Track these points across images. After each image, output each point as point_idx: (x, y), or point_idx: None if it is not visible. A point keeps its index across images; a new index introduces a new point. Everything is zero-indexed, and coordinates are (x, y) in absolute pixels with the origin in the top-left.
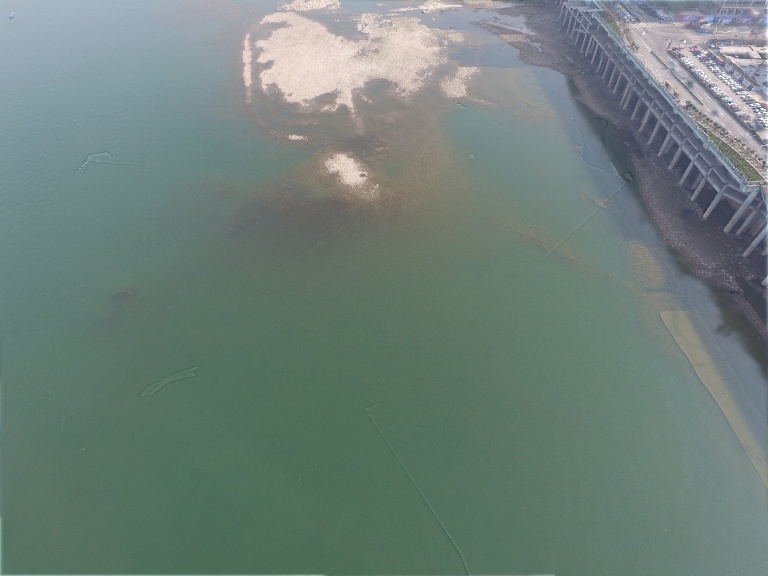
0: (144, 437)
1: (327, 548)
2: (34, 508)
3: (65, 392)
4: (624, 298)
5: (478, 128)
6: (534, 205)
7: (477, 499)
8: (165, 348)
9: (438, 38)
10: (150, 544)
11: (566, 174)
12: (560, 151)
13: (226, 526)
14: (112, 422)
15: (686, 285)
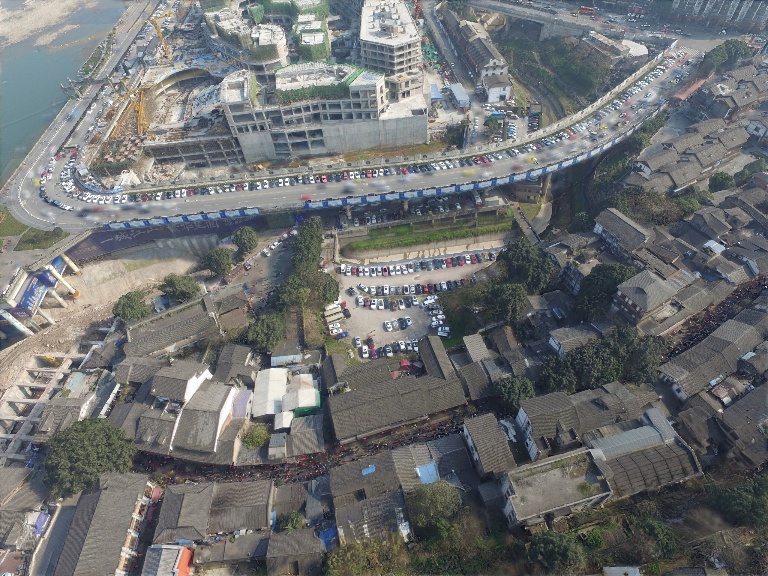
0: None
1: None
2: None
3: None
4: (2, 154)
5: (33, 65)
6: (10, 108)
7: None
8: None
9: (77, 6)
10: None
11: (57, 89)
12: (73, 76)
13: None
14: None
15: None
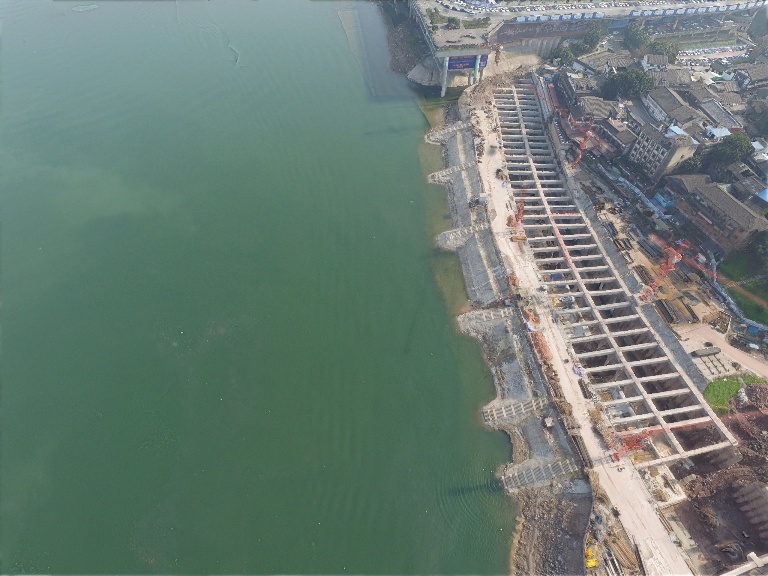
0: (76, 46)
1: (159, 69)
2: (25, 65)
3: (34, 43)
4: (325, 9)
5: None
6: None
7: (208, 19)
8: (86, 28)
9: None
10: (80, 71)
11: None
12: None
13: (115, 68)
14: (60, 49)
15: (357, 4)
